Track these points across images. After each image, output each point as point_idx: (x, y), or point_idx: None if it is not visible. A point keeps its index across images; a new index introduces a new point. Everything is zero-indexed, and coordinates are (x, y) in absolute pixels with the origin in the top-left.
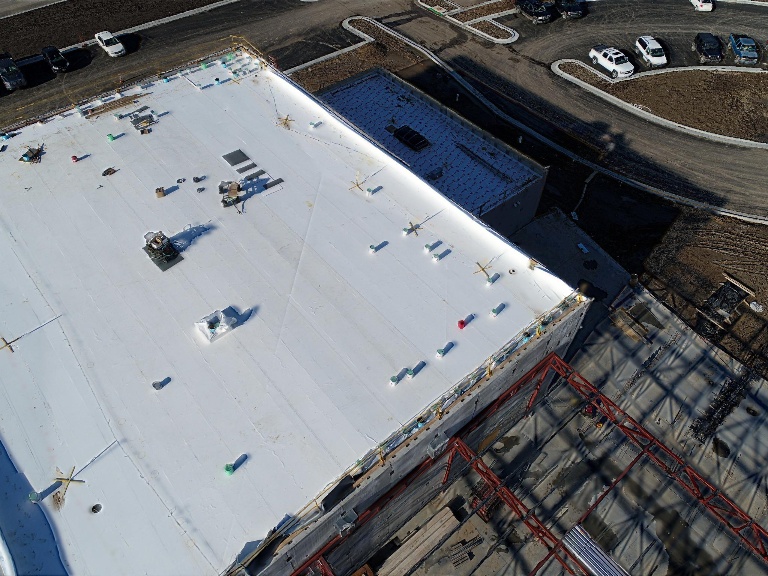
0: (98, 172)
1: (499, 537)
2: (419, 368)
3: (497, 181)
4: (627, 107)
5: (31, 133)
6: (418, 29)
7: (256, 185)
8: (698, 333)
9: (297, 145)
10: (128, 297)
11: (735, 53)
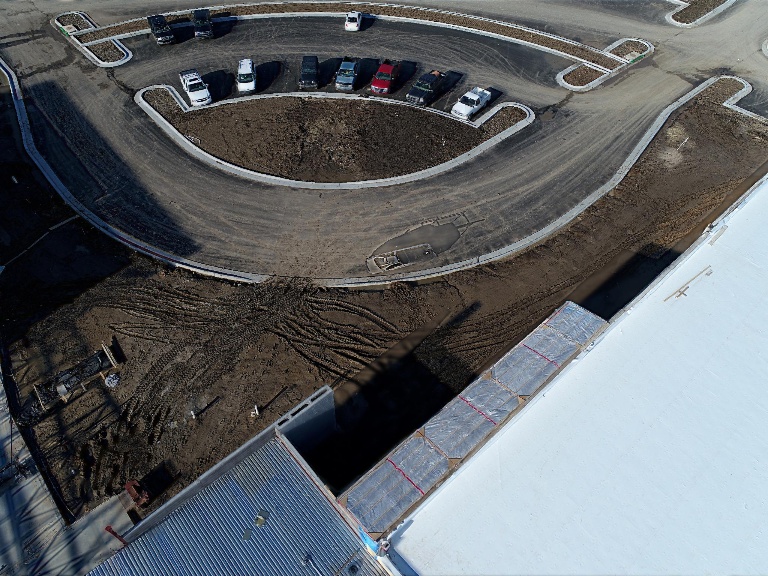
0: None
1: None
2: None
3: None
4: (178, 140)
5: None
6: (26, 51)
7: None
8: (16, 415)
9: None
10: None
11: None
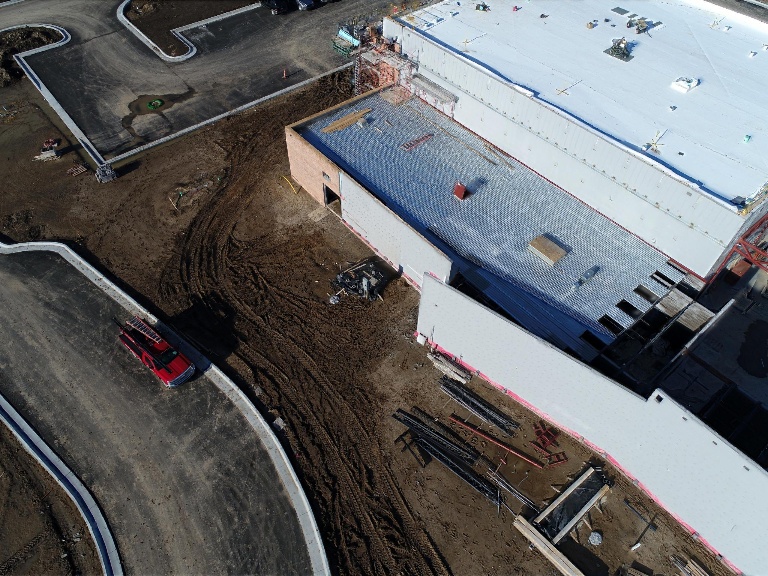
0: (536, 16)
1: None
2: None
3: None
4: None
5: None
6: None
7: (647, 24)
8: None
9: (655, 6)
10: (616, 73)
11: None
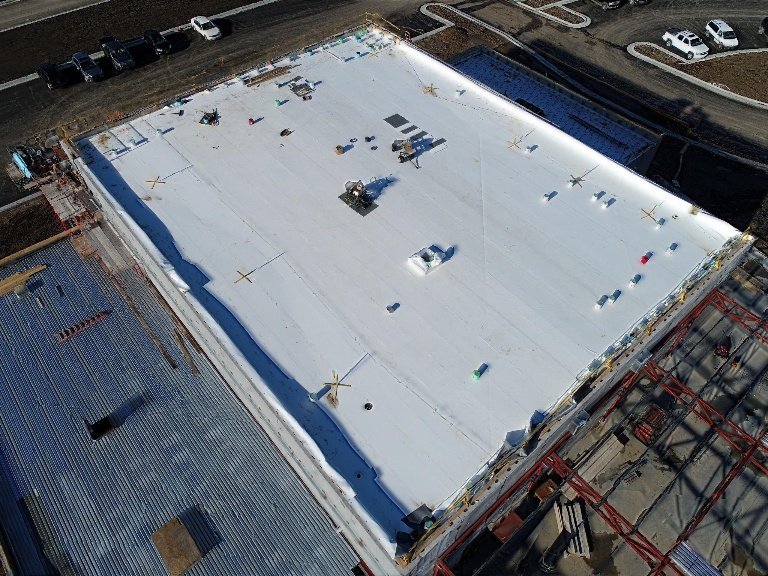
0: (275, 133)
1: (660, 458)
2: (616, 295)
3: (615, 148)
4: (706, 86)
5: (202, 100)
6: (493, 14)
7: (423, 144)
8: None
9: (448, 110)
10: (339, 238)
11: None
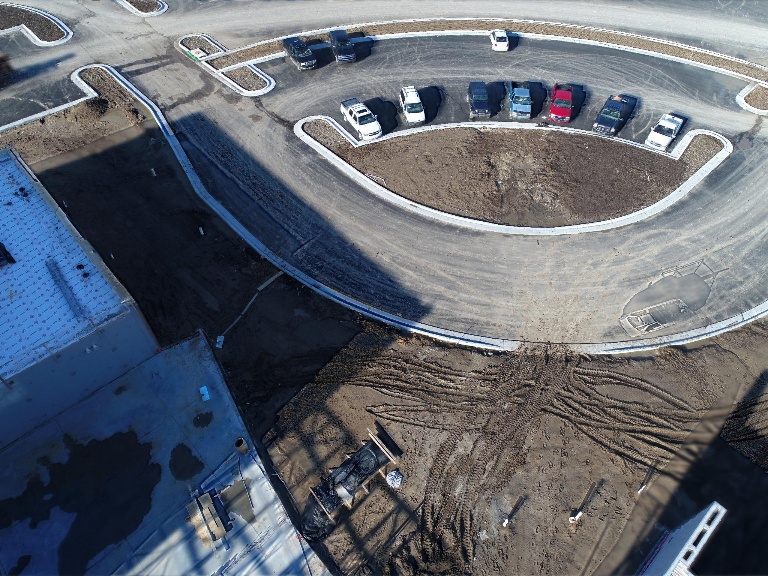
0: None
1: None
2: None
3: (67, 318)
4: (360, 179)
5: None
6: (160, 79)
7: None
8: (300, 527)
9: None
10: None
11: (510, 105)
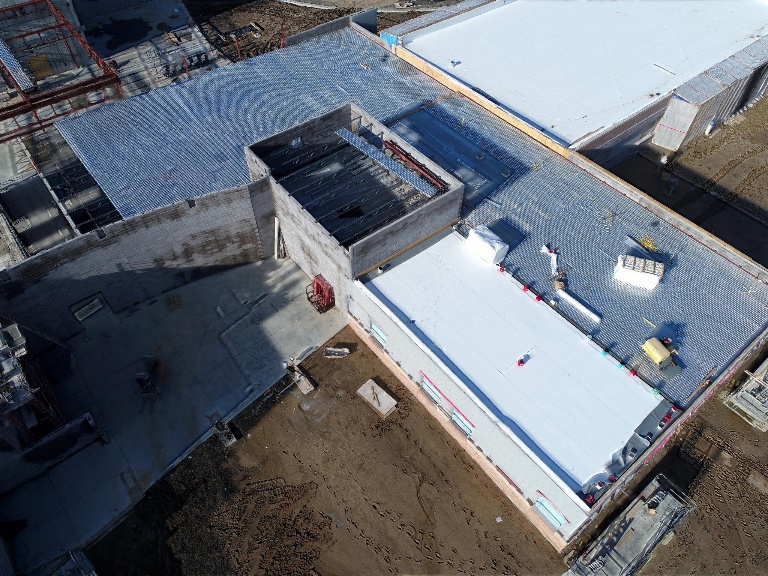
0: None
1: None
2: None
3: None
4: None
5: None
6: None
7: None
8: None
9: None
10: None
11: None
